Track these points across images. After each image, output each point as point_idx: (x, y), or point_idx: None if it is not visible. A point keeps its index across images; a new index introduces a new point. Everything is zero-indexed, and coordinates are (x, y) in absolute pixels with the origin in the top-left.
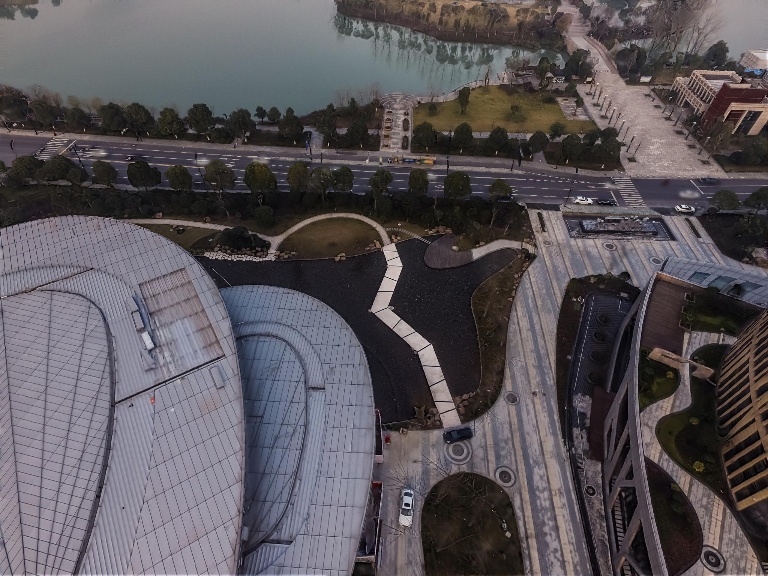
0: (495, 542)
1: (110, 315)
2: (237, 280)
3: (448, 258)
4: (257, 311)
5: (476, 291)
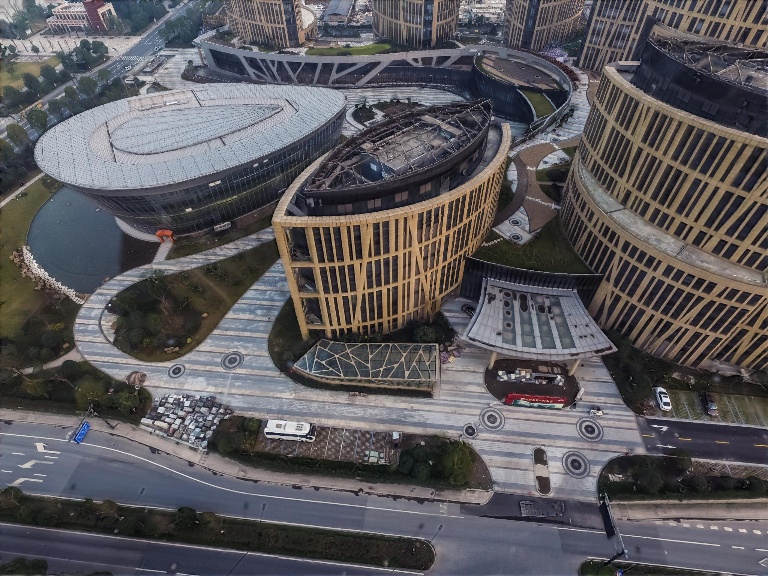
0: None
1: None
2: None
3: None
4: None
5: None
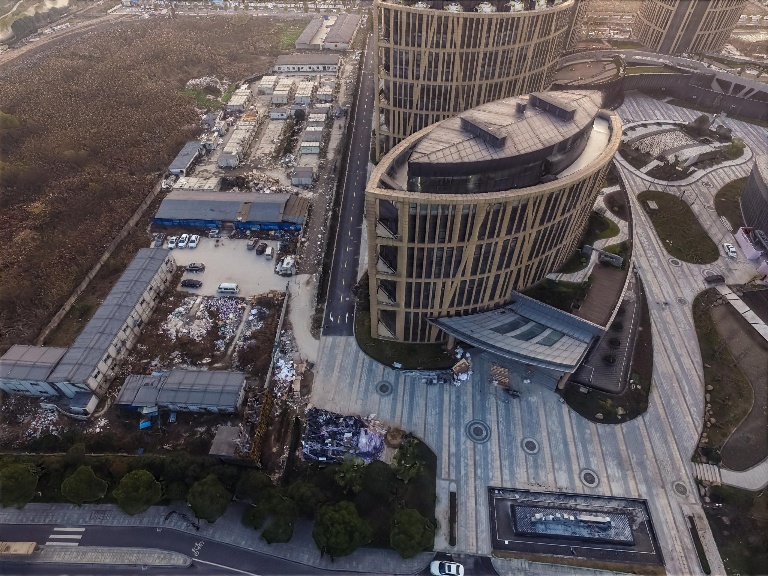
0: (675, 238)
1: None
2: None
3: None
4: None
5: (753, 399)
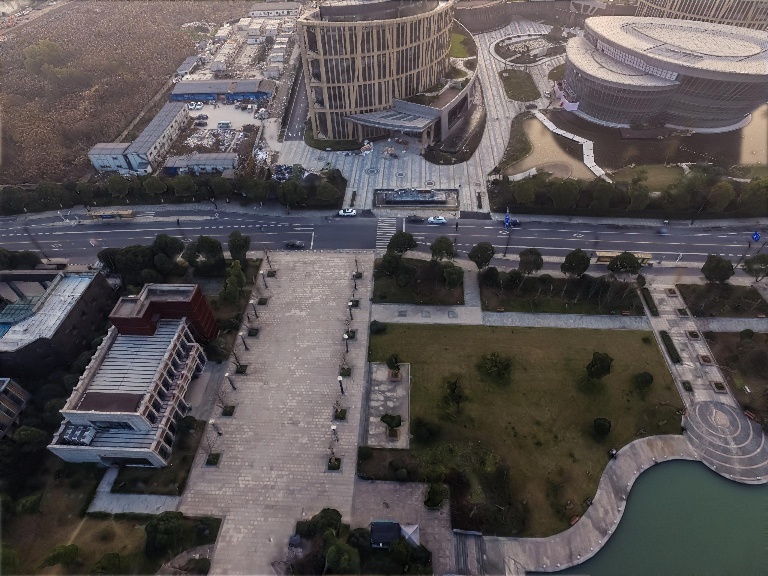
0: (515, 90)
1: (702, 54)
2: (691, 154)
3: (554, 168)
4: (647, 79)
5: (530, 152)
